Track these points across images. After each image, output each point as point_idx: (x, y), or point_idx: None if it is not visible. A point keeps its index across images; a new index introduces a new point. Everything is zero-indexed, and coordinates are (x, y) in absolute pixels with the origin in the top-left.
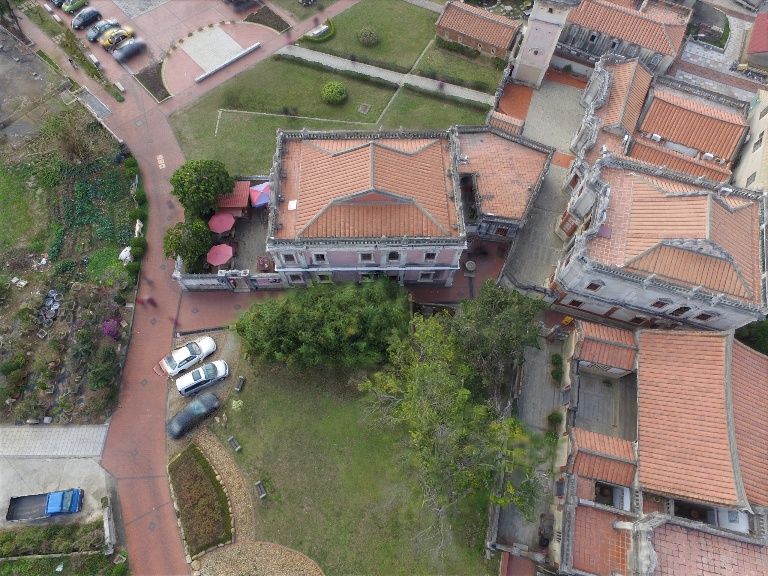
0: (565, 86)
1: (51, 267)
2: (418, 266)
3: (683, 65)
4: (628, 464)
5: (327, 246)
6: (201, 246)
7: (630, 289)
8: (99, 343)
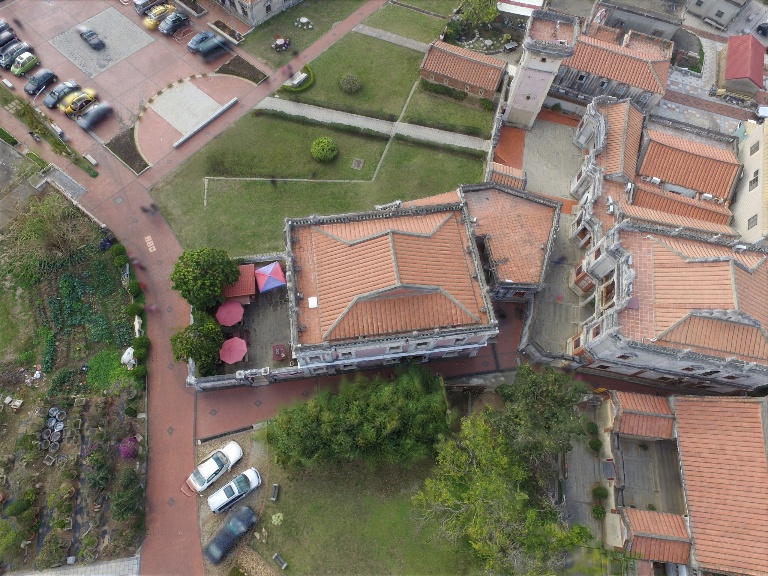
0: (556, 125)
1: (46, 380)
2: (445, 347)
3: (665, 93)
4: (683, 542)
5: (356, 346)
6: (214, 346)
7: (662, 359)
8: (114, 463)
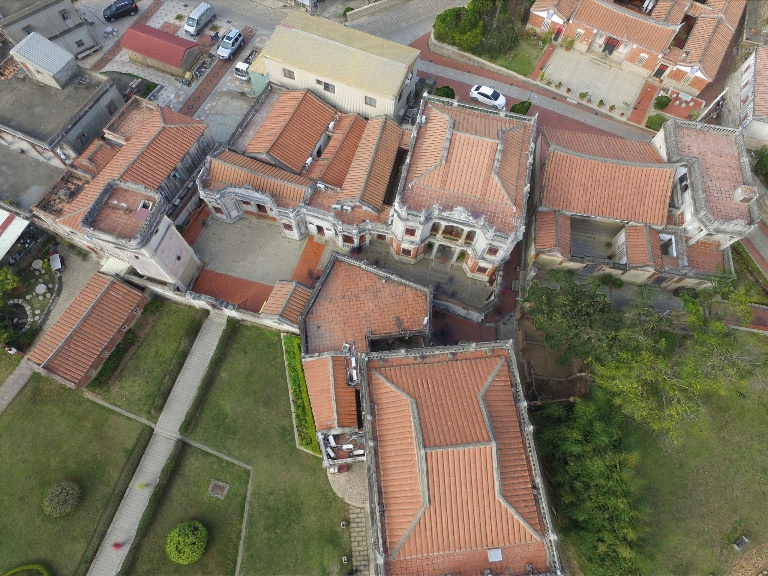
0: (202, 235)
1: None
2: None
3: None
4: None
5: None
6: None
7: None
8: None
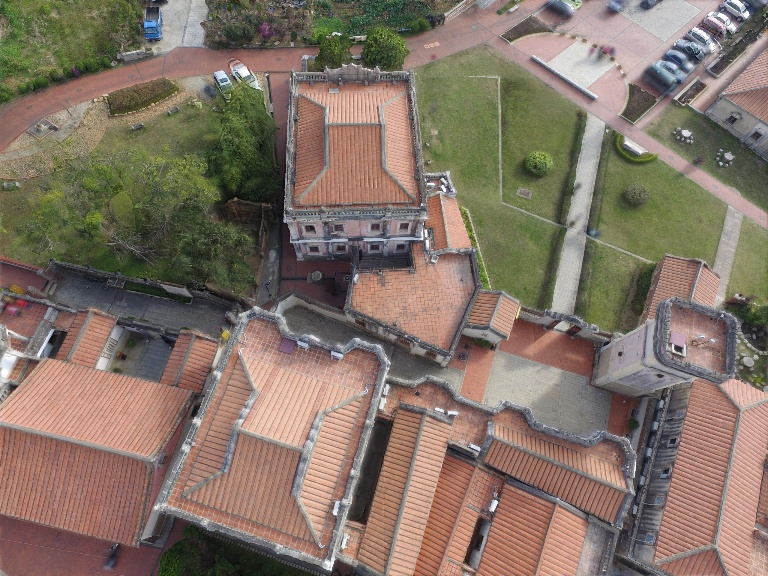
0: (605, 421)
1: None
2: None
3: None
4: None
5: None
6: (326, 63)
7: None
8: None
